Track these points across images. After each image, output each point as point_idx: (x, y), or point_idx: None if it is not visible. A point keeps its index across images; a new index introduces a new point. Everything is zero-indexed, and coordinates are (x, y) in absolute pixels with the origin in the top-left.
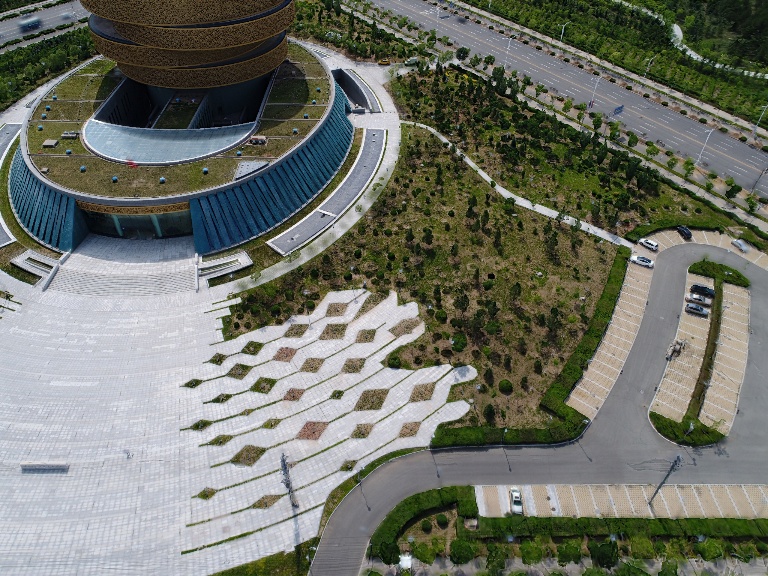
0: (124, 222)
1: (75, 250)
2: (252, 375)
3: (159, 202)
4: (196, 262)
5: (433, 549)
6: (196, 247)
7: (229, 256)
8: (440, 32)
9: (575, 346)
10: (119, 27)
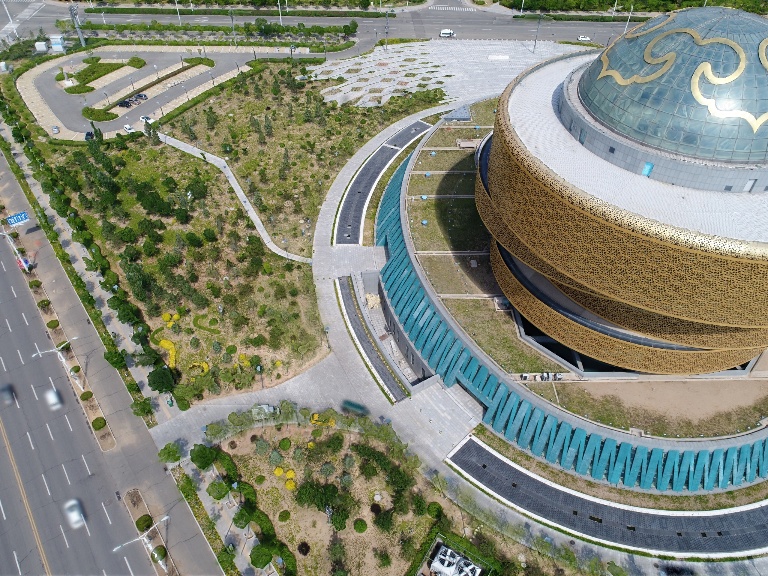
0: None
1: None
2: (418, 78)
3: None
4: None
5: (331, 29)
6: None
7: None
8: None
9: (233, 86)
10: None
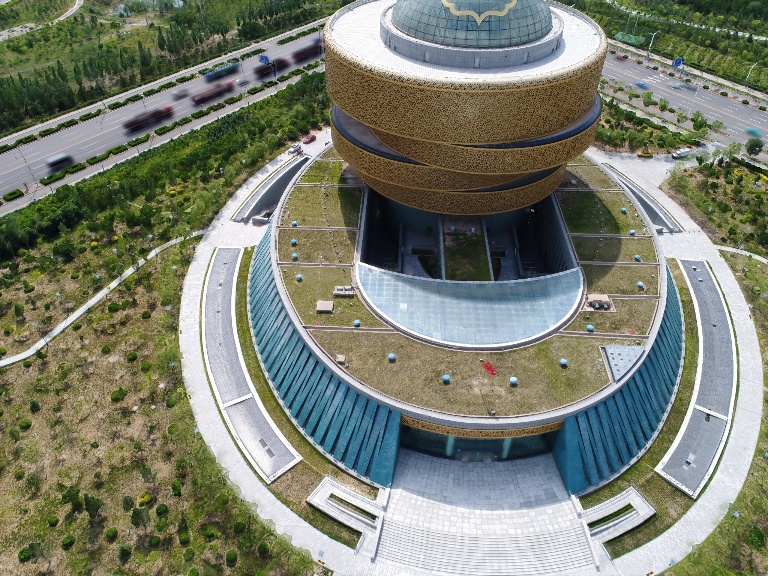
0: (462, 442)
1: (393, 482)
2: None
3: (527, 424)
4: (578, 512)
5: None
6: (570, 484)
7: (615, 497)
8: (686, 109)
9: None
10: (392, 139)
